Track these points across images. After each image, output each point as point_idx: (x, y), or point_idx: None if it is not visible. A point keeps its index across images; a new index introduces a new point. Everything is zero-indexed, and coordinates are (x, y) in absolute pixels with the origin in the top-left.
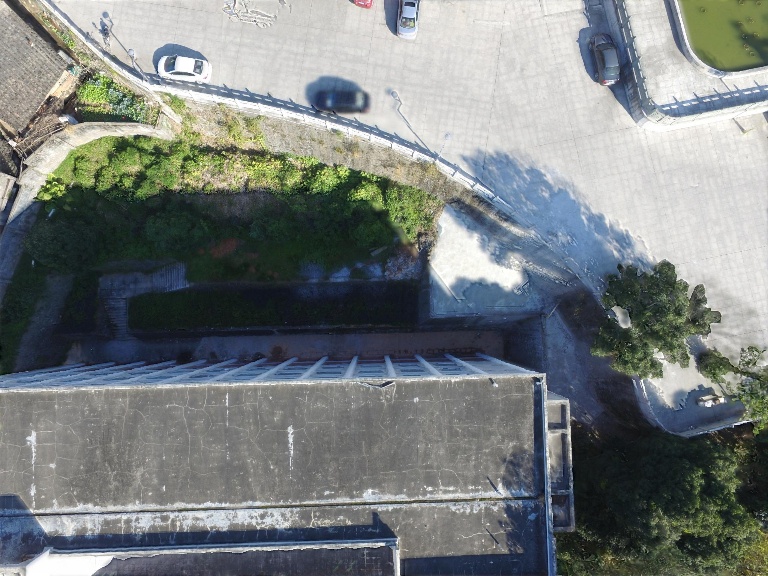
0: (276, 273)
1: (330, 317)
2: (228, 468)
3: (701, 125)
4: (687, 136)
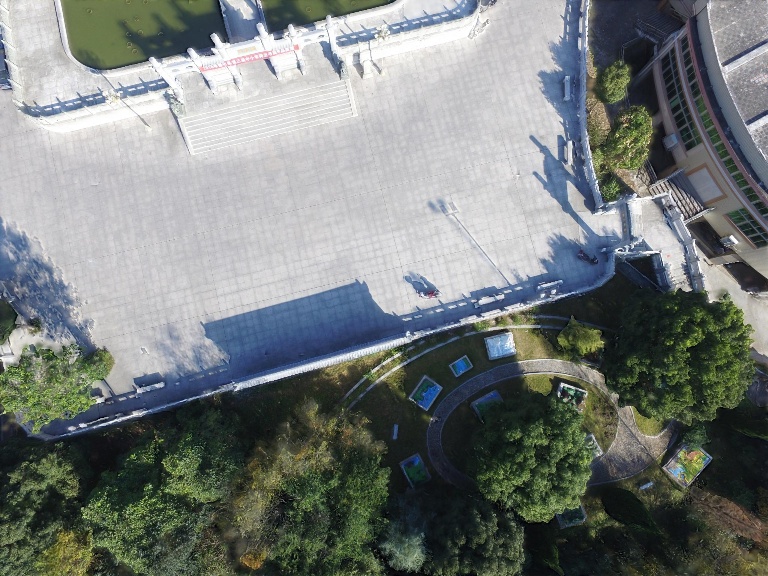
0: None
1: None
2: None
3: (106, 124)
4: (91, 135)
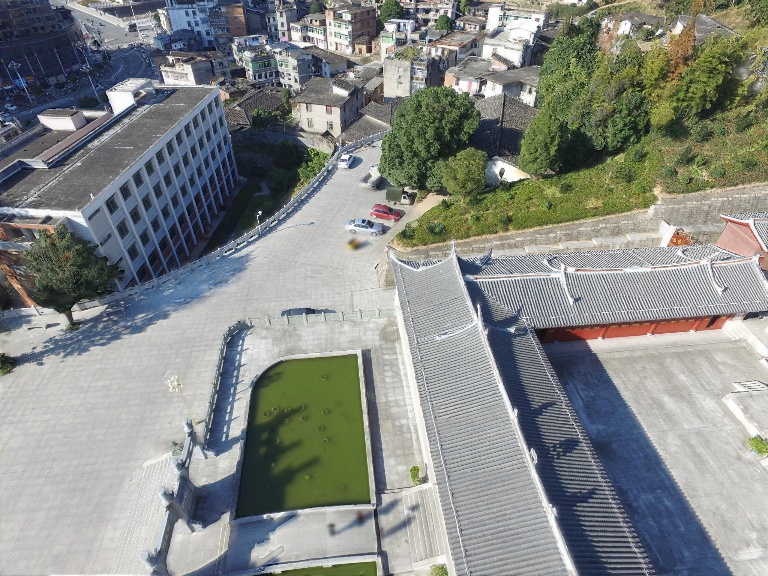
0: (245, 221)
1: (209, 247)
2: (130, 135)
3: None
4: None
